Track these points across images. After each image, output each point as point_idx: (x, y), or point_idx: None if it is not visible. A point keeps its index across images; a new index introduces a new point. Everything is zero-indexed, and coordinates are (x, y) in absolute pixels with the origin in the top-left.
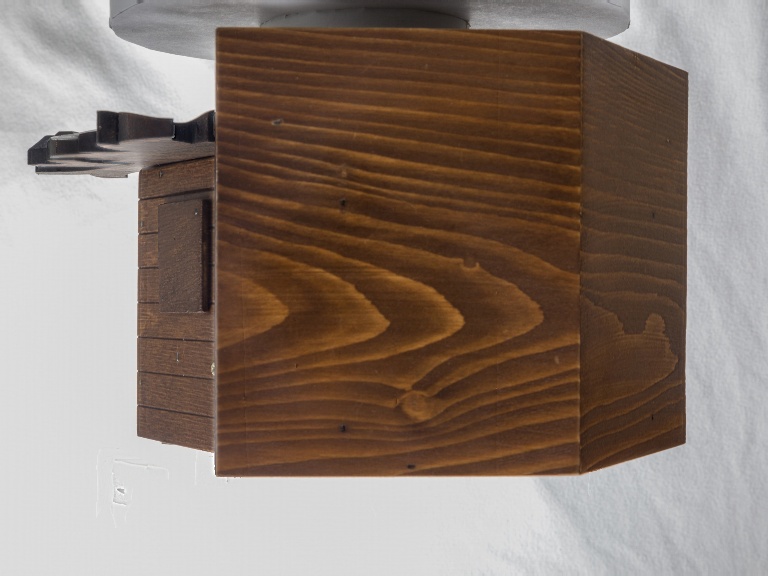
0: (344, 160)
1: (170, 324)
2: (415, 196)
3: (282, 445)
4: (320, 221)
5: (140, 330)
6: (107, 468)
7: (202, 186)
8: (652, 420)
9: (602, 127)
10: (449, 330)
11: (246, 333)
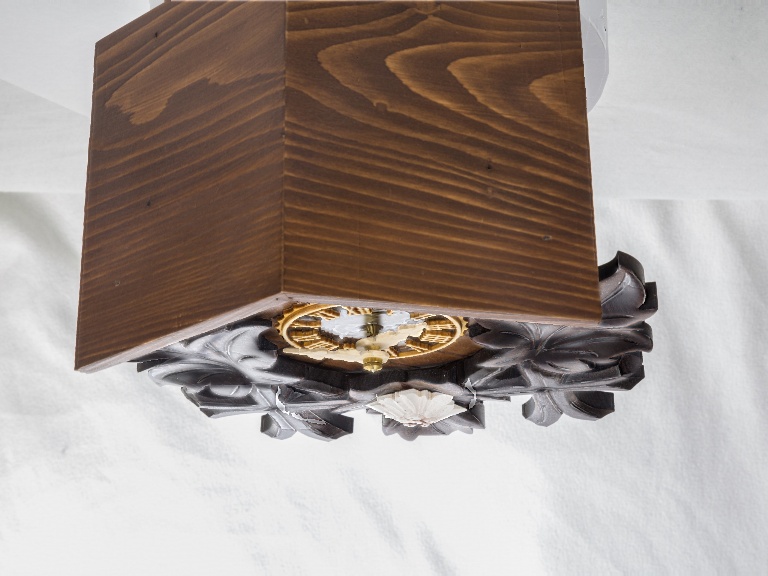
0: (490, 201)
1: None
2: (430, 166)
3: None
4: (508, 154)
5: None
6: None
7: None
8: (157, 32)
9: (245, 228)
10: (398, 56)
11: (562, 76)
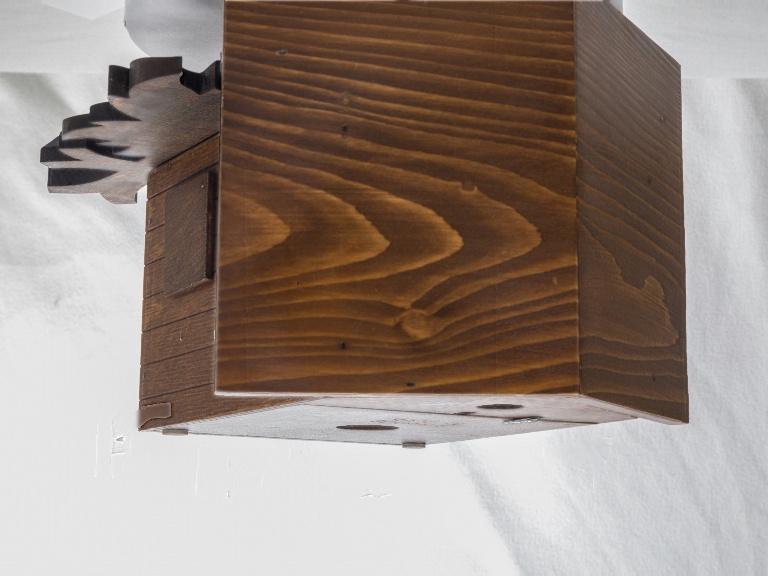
0: (346, 88)
1: (174, 307)
2: (414, 123)
3: (282, 361)
4: (322, 145)
5: (144, 324)
6: (107, 423)
7: (209, 163)
8: (654, 381)
9: (596, 71)
10: (448, 251)
11: (248, 251)
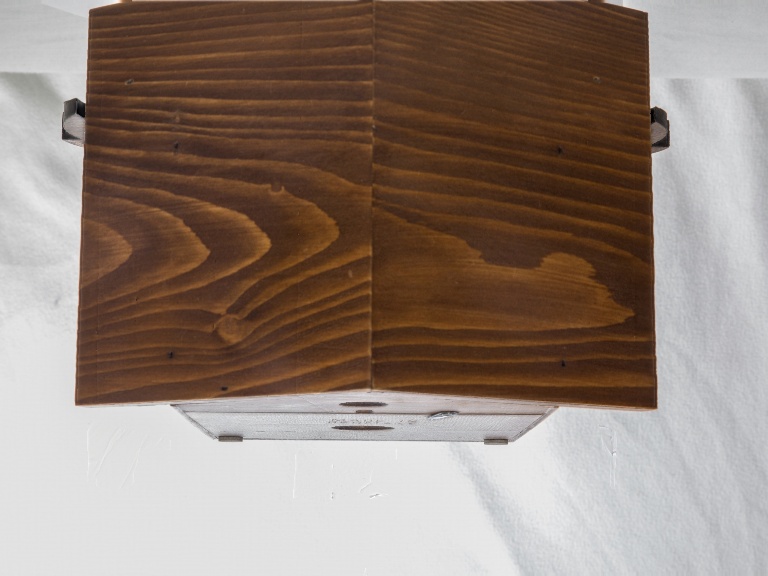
0: (178, 107)
1: None
2: (232, 131)
3: (123, 374)
4: (158, 165)
5: None
6: None
7: None
8: (562, 367)
9: (424, 47)
10: (258, 254)
11: (100, 273)
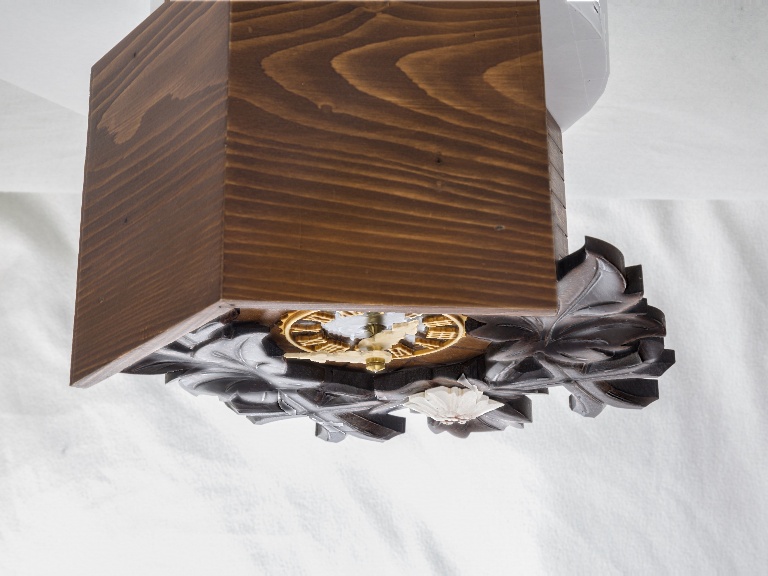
0: (440, 195)
1: None
2: (376, 164)
3: None
4: (459, 146)
5: None
6: None
7: None
8: (136, 52)
9: (195, 239)
10: (345, 57)
11: (518, 62)
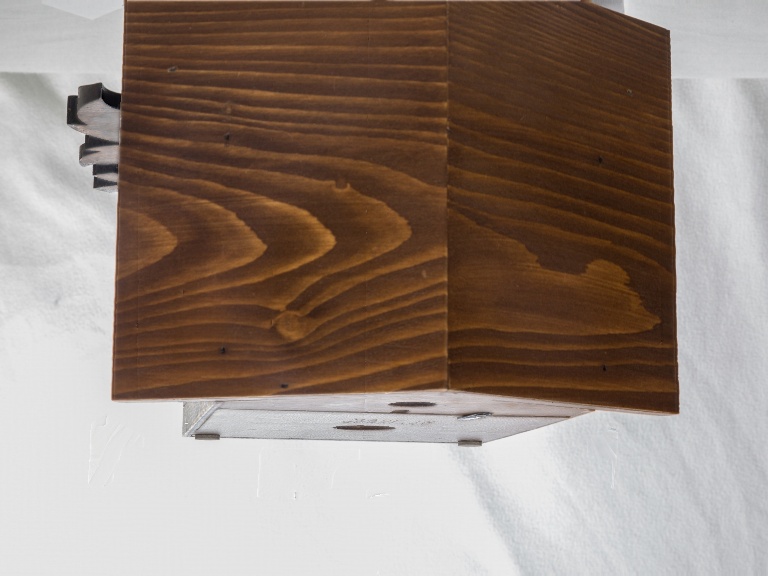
0: (229, 98)
1: None
2: (291, 125)
3: (168, 368)
4: (207, 156)
5: None
6: None
7: None
8: (604, 371)
9: (489, 52)
10: (321, 250)
11: (140, 264)
